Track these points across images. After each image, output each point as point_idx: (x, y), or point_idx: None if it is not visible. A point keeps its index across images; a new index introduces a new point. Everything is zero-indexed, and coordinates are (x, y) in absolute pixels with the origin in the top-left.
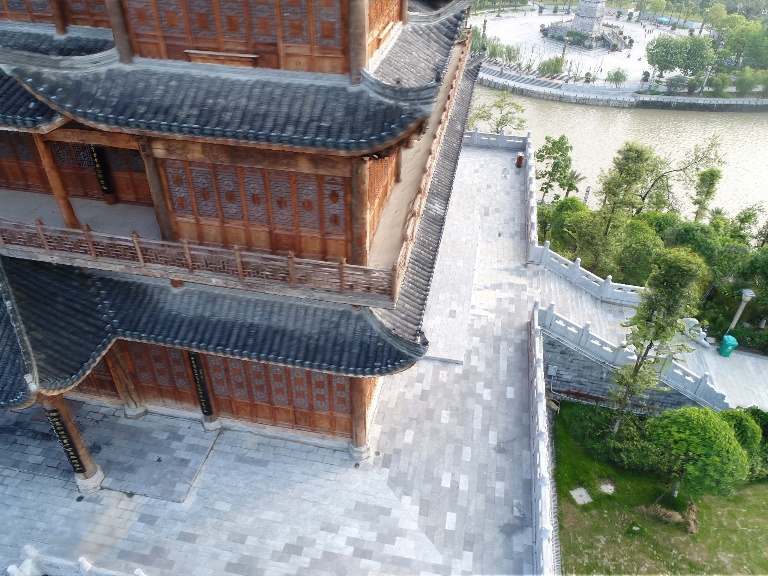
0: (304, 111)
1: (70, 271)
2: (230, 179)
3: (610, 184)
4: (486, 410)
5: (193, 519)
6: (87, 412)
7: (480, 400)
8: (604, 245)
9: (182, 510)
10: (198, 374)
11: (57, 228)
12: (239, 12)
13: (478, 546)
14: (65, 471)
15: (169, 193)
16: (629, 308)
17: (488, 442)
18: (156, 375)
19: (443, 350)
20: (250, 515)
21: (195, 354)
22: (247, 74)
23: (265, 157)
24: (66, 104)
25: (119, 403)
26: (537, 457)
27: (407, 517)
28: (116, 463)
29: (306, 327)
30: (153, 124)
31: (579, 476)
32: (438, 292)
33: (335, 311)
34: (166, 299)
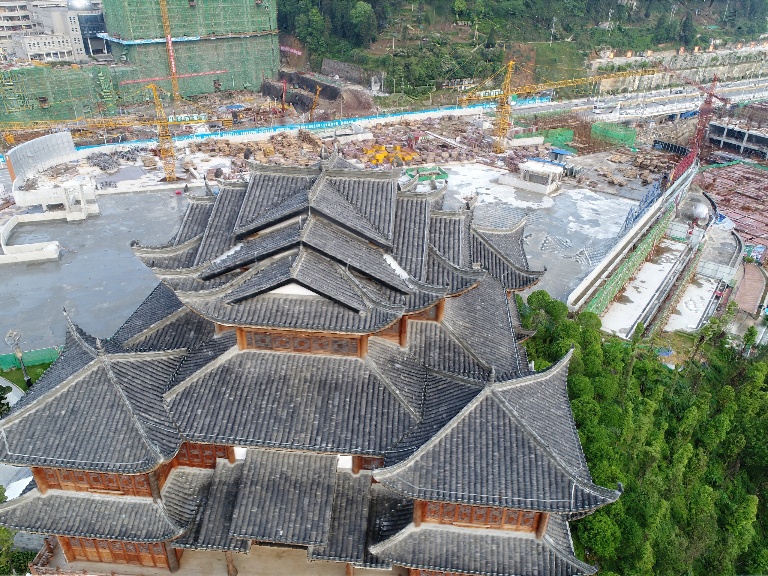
0: None
1: None
2: None
3: None
4: None
5: None
6: None
7: None
8: None
9: None
10: None
11: None
12: None
13: None
14: None
15: None
16: None
17: None
18: None
19: None
20: None
21: None
22: None
23: None
24: None
25: None
26: None
27: None
28: None
29: None
30: None
31: None
32: None
33: None
34: None
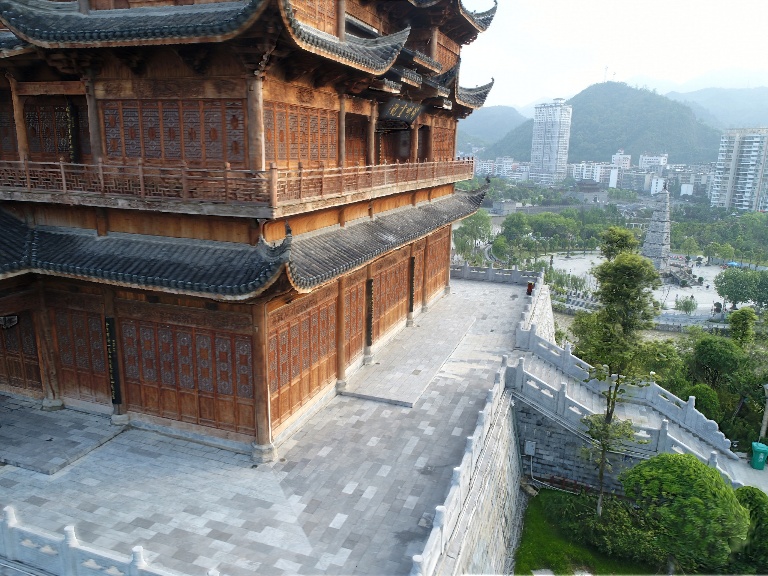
0: (200, 20)
1: (17, 224)
2: (153, 115)
3: None
4: (423, 441)
5: (52, 488)
6: (8, 403)
7: (419, 433)
8: None
9: (46, 480)
10: (111, 345)
11: (5, 161)
12: None
13: (361, 545)
14: None
15: (105, 135)
16: (632, 404)
17: (414, 464)
18: (77, 355)
19: (394, 394)
20: (114, 491)
21: (110, 319)
22: (169, 11)
23: (180, 87)
24: (21, 24)
25: (41, 397)
26: None
27: (288, 511)
28: (7, 438)
29: (201, 261)
30: (80, 34)
31: (546, 556)
32: (408, 358)
33: (234, 250)
34: (87, 244)
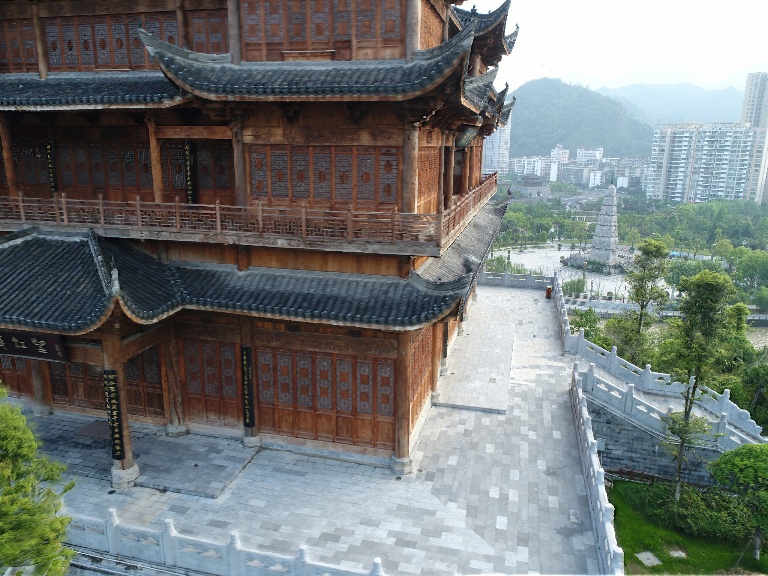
0: (370, 78)
1: (151, 260)
2: (302, 159)
3: (635, 281)
4: (532, 445)
5: (226, 511)
6: (130, 431)
7: (525, 438)
8: (638, 340)
9: (215, 504)
10: (247, 373)
11: None
12: (325, 20)
13: (533, 543)
14: (101, 470)
15: (250, 177)
16: (674, 399)
17: (537, 467)
18: (205, 383)
19: (485, 402)
20: (285, 510)
21: (248, 348)
22: (326, 65)
23: (334, 135)
24: (189, 78)
25: (162, 423)
26: (591, 470)
27: (453, 517)
28: (153, 466)
29: (357, 294)
30: (252, 89)
31: (643, 540)
32: (477, 367)
33: (384, 283)
34: (232, 279)
